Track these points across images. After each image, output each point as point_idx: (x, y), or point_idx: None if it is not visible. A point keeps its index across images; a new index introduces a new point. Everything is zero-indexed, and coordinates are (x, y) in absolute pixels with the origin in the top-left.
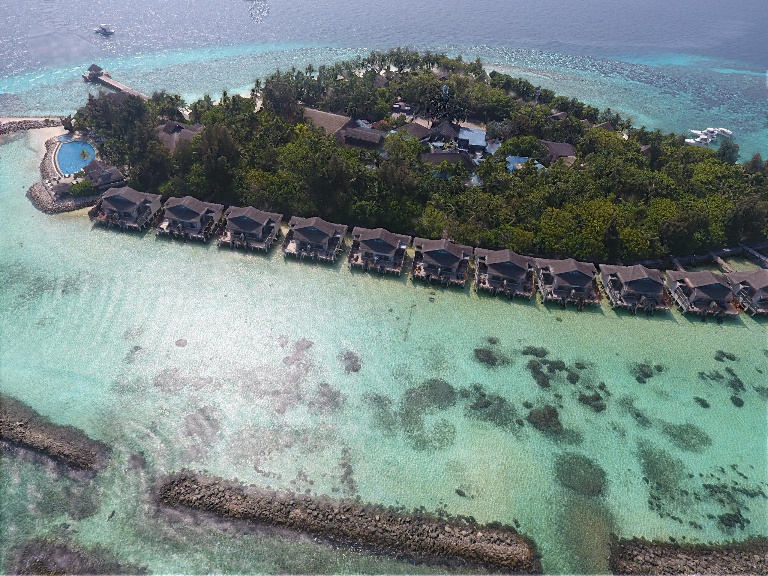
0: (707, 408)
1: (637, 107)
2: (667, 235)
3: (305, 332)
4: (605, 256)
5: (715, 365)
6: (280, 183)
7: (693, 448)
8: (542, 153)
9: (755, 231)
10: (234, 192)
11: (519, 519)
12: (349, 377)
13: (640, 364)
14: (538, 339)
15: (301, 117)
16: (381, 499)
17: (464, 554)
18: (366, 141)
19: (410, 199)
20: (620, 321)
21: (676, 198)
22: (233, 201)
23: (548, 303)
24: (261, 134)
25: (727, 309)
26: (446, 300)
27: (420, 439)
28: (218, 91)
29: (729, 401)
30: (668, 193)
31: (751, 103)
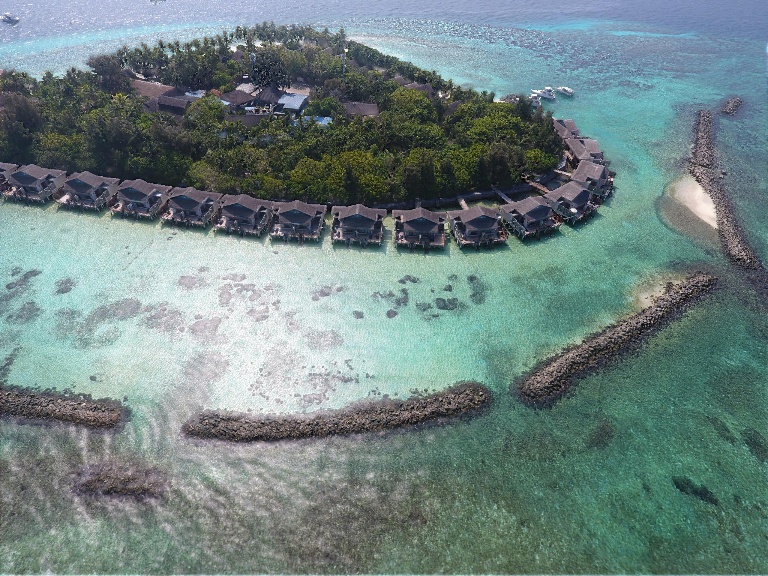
0: (359, 319)
1: (498, 71)
2: (405, 179)
3: (40, 264)
4: (345, 199)
5: (394, 286)
6: (72, 144)
7: (322, 348)
8: (339, 113)
9: (502, 175)
10: (30, 153)
11: (130, 396)
12: (55, 297)
13: (324, 286)
14: (245, 268)
15: (127, 88)
16: (24, 382)
17: (62, 417)
18: (175, 107)
19: (180, 154)
20: (332, 253)
21: (438, 148)
22: (31, 162)
23: (275, 240)
24: (74, 103)
25: (434, 241)
26: (183, 239)
27: (86, 341)
28: (87, 70)
29: (384, 313)
30: (432, 143)
31: (623, 63)
